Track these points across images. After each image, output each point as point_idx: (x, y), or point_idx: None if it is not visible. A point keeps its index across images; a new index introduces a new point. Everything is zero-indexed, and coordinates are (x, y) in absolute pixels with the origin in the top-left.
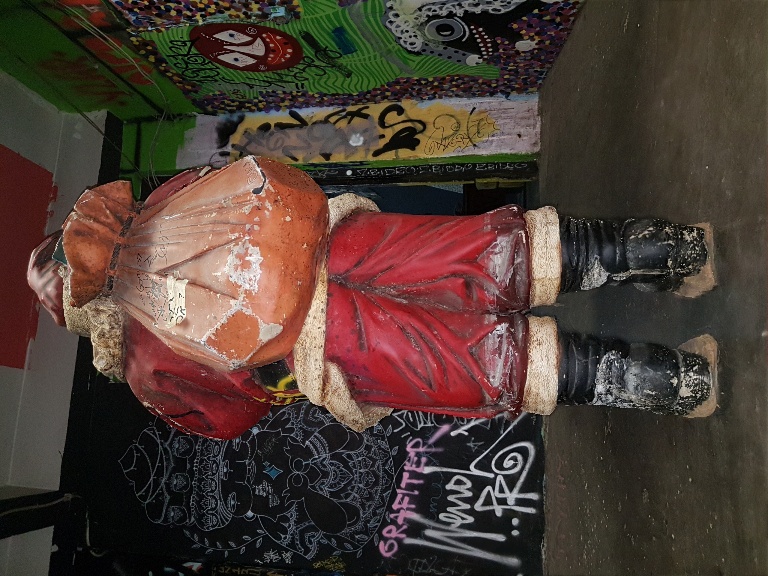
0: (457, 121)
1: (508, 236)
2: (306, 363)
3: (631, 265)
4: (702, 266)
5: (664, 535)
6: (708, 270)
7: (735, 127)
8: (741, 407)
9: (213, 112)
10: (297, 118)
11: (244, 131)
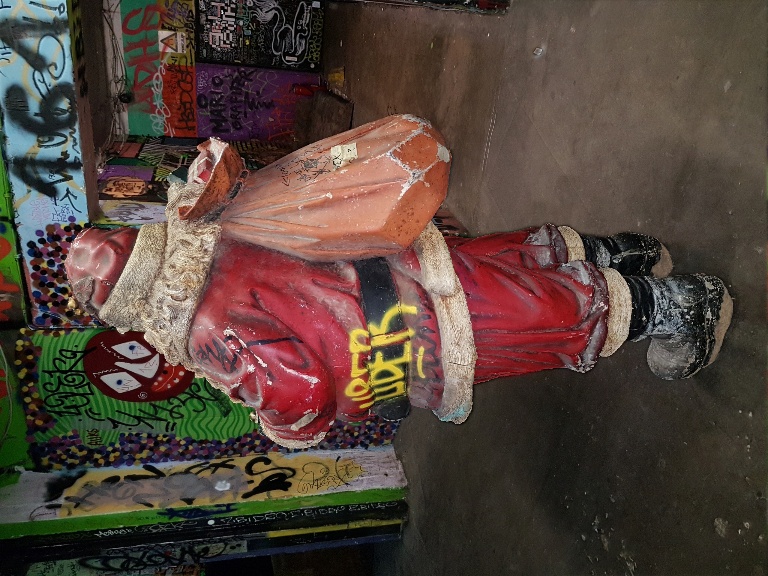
0: (325, 466)
1: (537, 232)
2: (436, 251)
3: (621, 248)
4: (661, 249)
5: (767, 509)
6: (665, 251)
7: (631, 194)
8: (748, 277)
9: (46, 468)
10: (153, 470)
11: (84, 484)
